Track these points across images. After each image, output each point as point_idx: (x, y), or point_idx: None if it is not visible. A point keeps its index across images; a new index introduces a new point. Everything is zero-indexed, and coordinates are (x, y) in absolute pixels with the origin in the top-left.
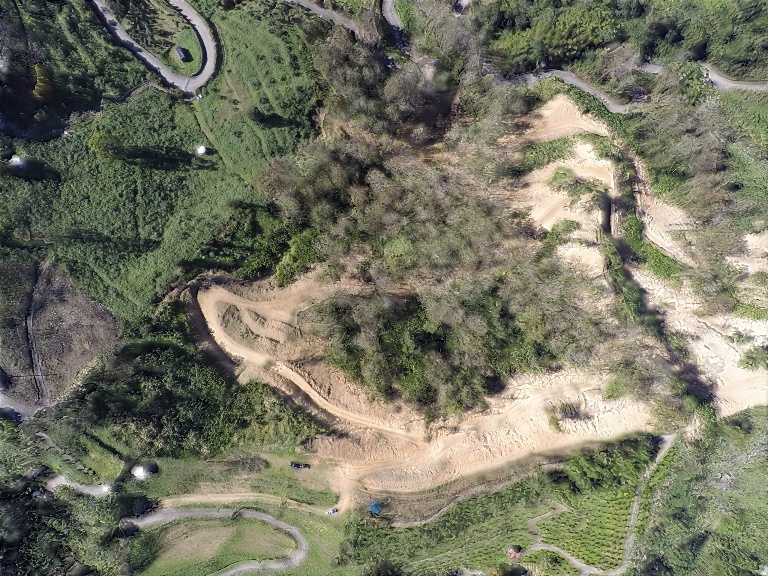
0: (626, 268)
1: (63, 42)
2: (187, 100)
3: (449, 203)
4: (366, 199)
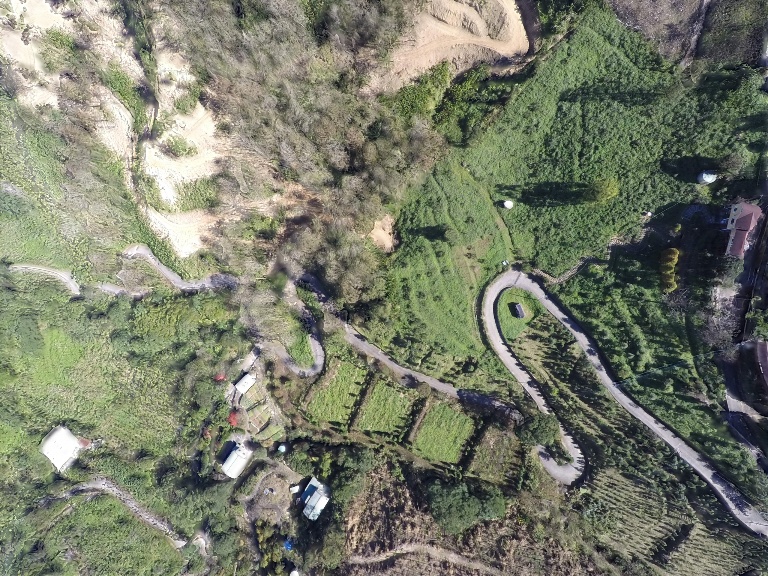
0: (148, 78)
1: (646, 324)
2: (520, 262)
3: (271, 111)
4: (348, 130)
